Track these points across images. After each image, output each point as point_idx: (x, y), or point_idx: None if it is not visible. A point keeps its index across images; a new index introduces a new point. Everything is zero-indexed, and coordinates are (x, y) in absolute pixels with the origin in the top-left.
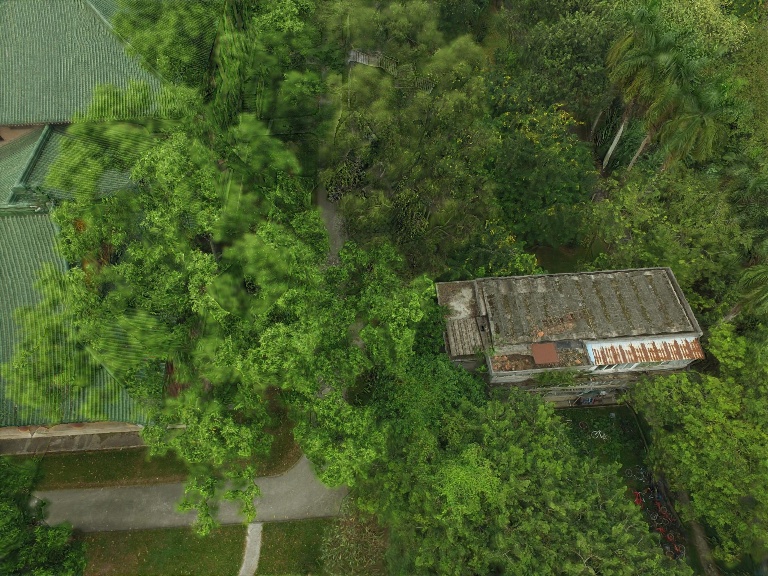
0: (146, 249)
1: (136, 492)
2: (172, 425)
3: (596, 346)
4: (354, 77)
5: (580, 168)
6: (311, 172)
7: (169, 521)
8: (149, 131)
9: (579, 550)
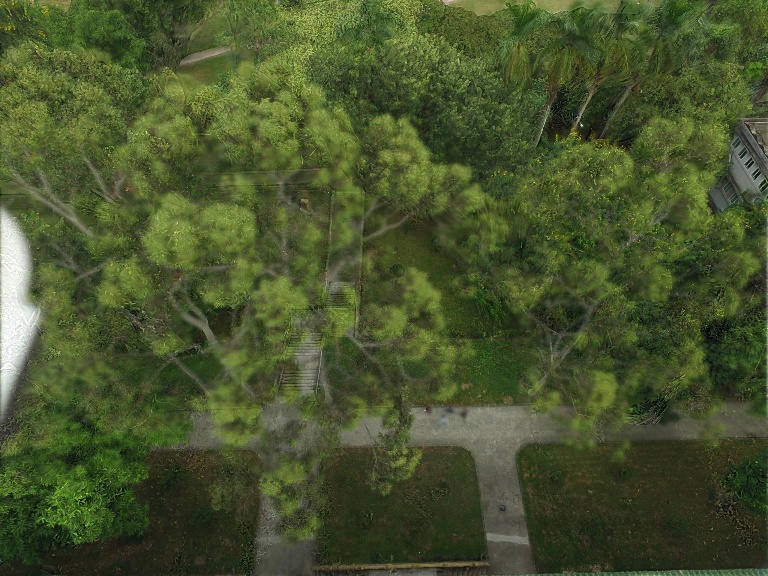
0: None
1: None
2: None
3: None
4: None
5: None
6: (610, 452)
7: None
8: None
9: None
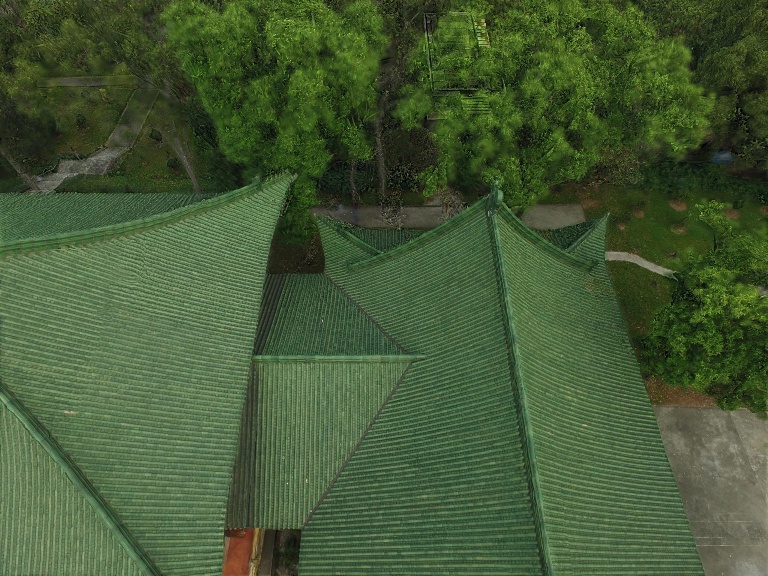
0: None
1: None
2: None
3: None
4: None
5: None
6: None
7: None
8: None
9: None
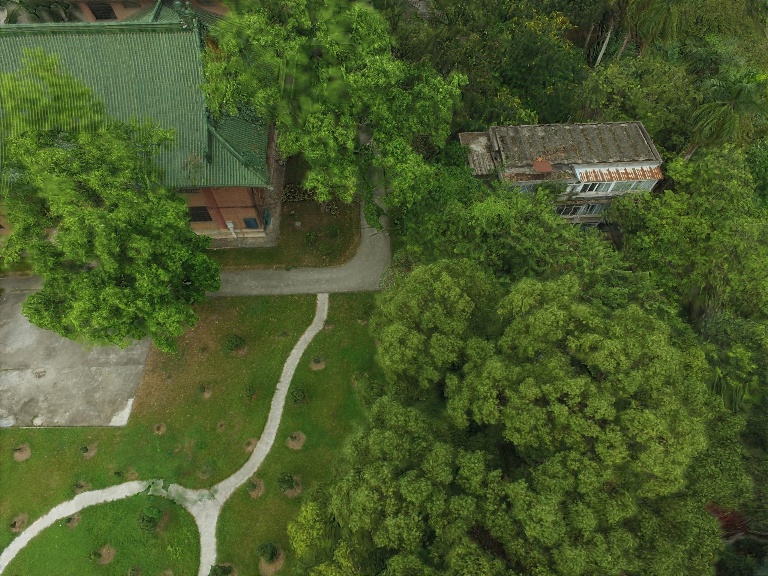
0: (283, 23)
1: (230, 275)
2: (254, 233)
3: (582, 170)
4: (384, 4)
5: (574, 61)
6: None
7: (257, 292)
8: (233, 13)
9: (564, 241)
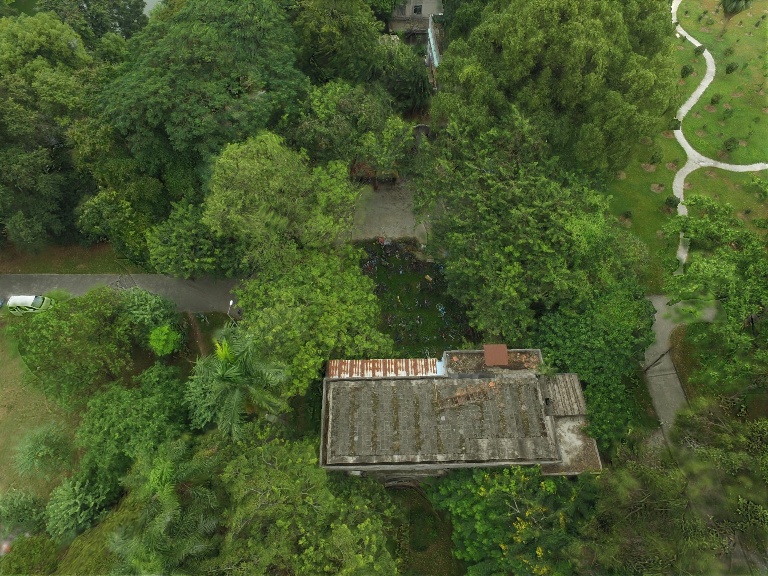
0: None
1: None
2: None
3: None
4: None
5: None
6: None
7: None
8: None
9: None
